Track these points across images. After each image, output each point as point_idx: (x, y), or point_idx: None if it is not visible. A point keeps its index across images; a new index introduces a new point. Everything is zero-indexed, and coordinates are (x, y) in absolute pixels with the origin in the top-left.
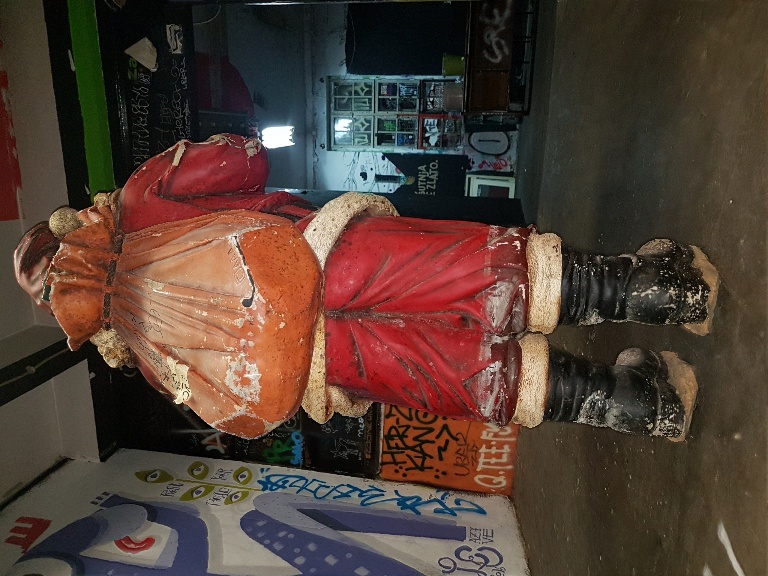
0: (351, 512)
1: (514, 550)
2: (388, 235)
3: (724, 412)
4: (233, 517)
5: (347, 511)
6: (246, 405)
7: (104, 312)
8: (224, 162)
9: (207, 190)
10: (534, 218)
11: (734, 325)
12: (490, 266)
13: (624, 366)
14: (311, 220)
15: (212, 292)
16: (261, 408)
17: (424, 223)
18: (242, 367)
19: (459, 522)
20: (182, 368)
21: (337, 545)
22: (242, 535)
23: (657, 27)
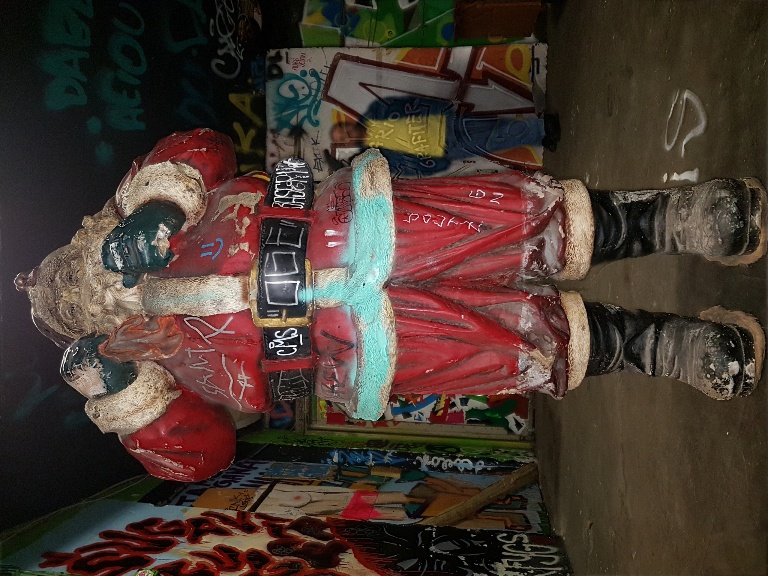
0: None
1: None
2: None
3: None
4: None
5: None
6: None
7: None
8: None
9: None
10: None
11: None
12: None
13: None
14: None
15: None
16: None
17: None
18: None
19: None
20: None
21: None
22: None
23: None
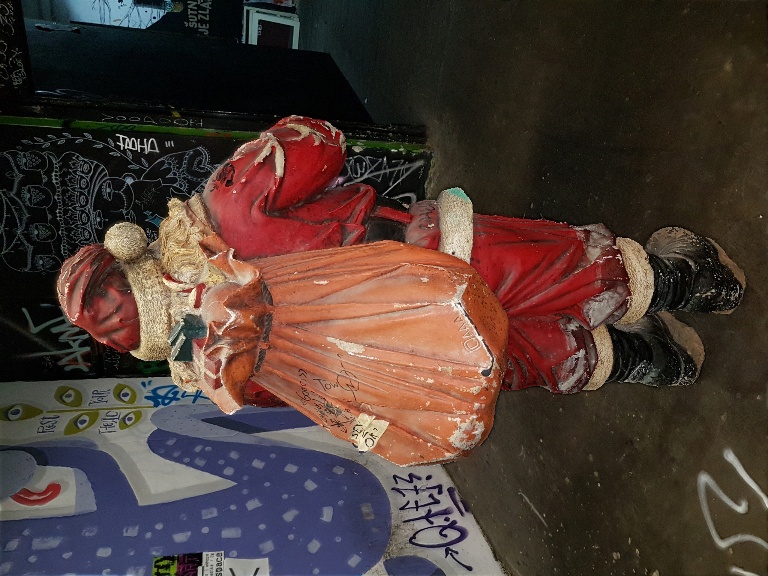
0: (256, 413)
1: None
2: (508, 250)
3: (739, 375)
4: (138, 442)
5: (252, 412)
6: (459, 452)
7: (256, 367)
8: (325, 166)
9: (306, 198)
10: (423, 119)
11: (759, 316)
12: (601, 279)
13: (647, 332)
14: (439, 238)
15: (434, 359)
16: (469, 451)
17: (516, 225)
18: (472, 427)
19: None
20: (380, 423)
21: (258, 448)
22: (155, 458)
23: (651, 3)
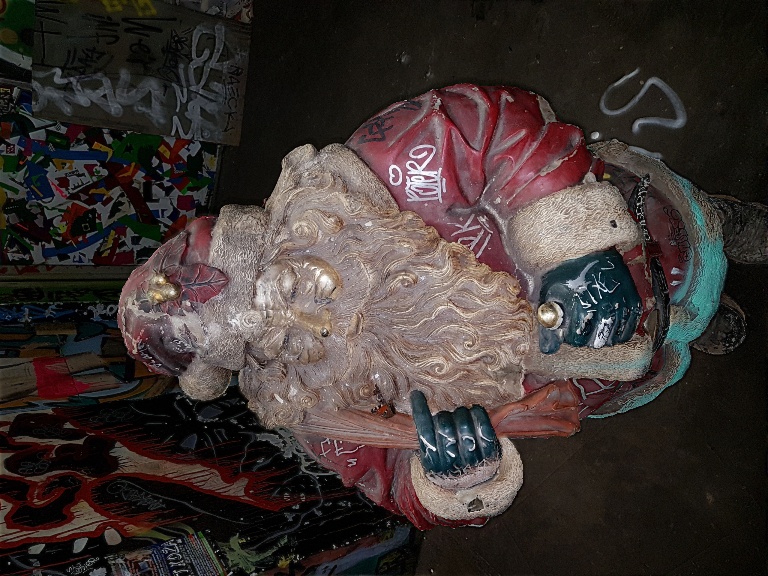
0: None
1: None
2: None
3: None
4: None
5: None
6: None
7: None
8: None
9: None
10: None
11: None
12: None
13: None
14: None
15: None
16: None
17: None
18: None
19: None
20: None
21: None
22: None
23: None
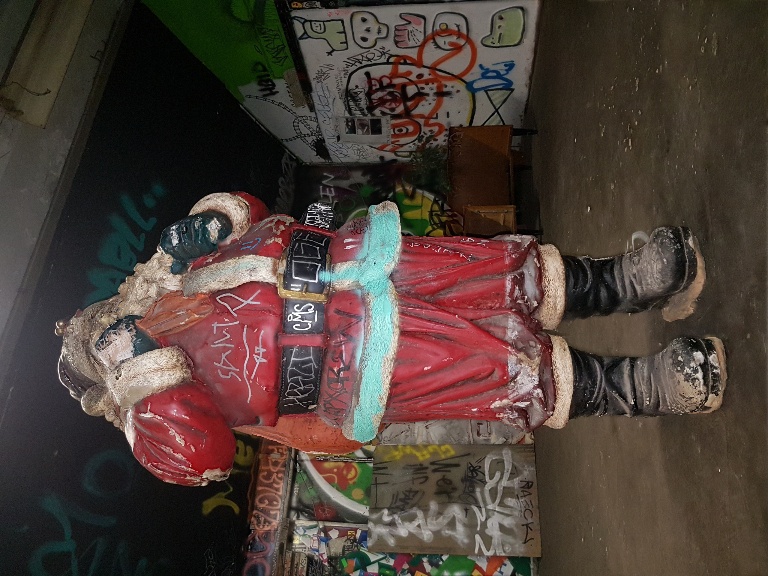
0: None
1: None
2: None
3: None
4: None
5: None
6: None
7: None
8: None
9: None
10: None
11: None
12: None
13: (633, 303)
14: None
15: None
16: None
17: None
18: None
19: None
20: None
21: None
22: None
23: None
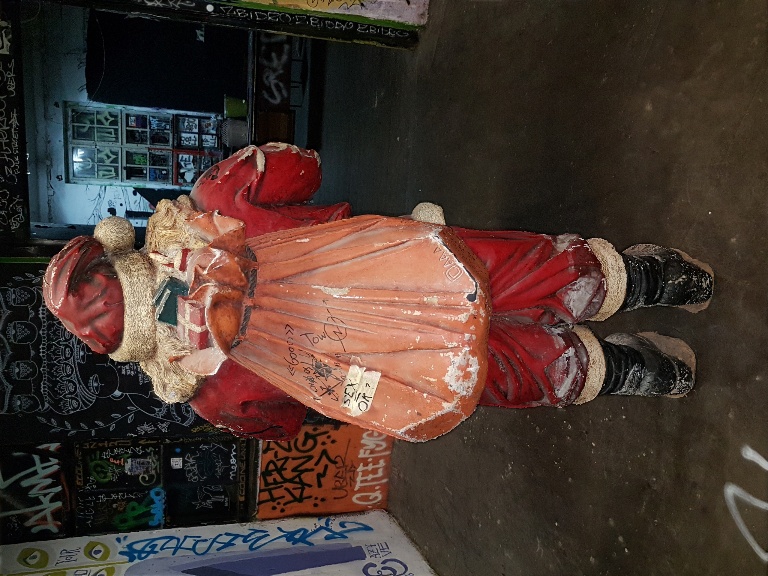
0: (244, 560)
1: (412, 555)
2: (481, 241)
3: (733, 365)
4: None
5: (239, 560)
6: (457, 400)
7: (242, 328)
8: (303, 171)
9: (286, 199)
10: None
11: (734, 300)
12: (574, 265)
13: None
14: None
15: (419, 291)
16: (468, 402)
17: None
18: (466, 361)
19: (353, 543)
20: (372, 375)
21: None
22: None
23: (575, 84)
